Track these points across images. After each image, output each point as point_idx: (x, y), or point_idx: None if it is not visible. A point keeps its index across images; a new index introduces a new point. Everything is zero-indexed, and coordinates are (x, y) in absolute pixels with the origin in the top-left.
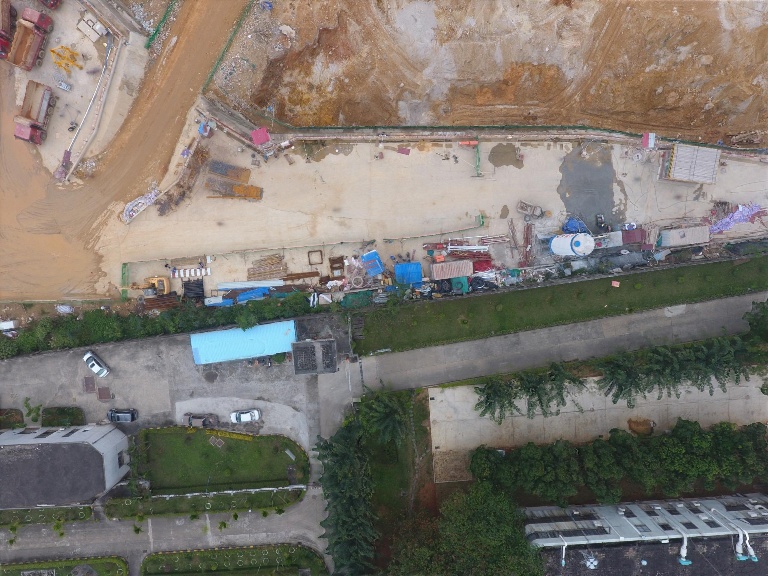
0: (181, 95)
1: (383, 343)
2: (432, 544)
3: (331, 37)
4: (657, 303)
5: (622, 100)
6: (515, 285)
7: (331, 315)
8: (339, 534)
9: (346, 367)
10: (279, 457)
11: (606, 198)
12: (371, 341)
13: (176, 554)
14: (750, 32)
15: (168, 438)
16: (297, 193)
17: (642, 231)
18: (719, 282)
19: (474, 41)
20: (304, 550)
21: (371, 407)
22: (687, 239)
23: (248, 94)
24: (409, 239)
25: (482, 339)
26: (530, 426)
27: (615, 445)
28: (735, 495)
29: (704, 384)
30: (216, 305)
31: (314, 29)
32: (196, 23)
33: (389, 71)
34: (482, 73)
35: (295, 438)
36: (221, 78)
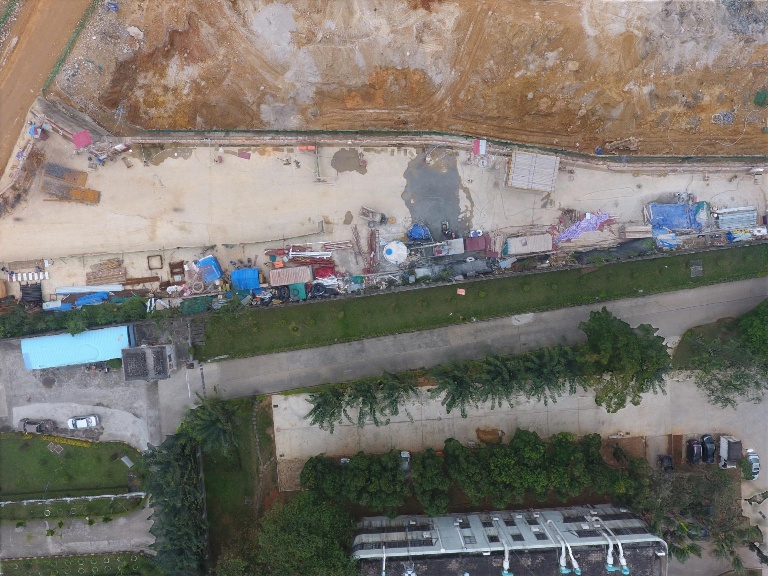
0: (21, 96)
1: (224, 349)
2: (251, 554)
3: (185, 39)
4: (503, 311)
5: (494, 105)
6: (356, 292)
7: (169, 321)
8: (164, 543)
9: (187, 373)
10: (119, 464)
11: (452, 205)
12: (212, 347)
13: (15, 561)
14: (614, 38)
15: (5, 444)
16: (136, 197)
17: (487, 238)
18: (567, 291)
19: (334, 45)
20: (145, 558)
21: (196, 415)
22: (529, 247)
23: (95, 96)
24: (251, 244)
25: (325, 346)
26: (376, 434)
27: (447, 455)
28: (585, 506)
29: (540, 394)
30: (54, 309)
31: (163, 31)
32: (38, 24)
33: (247, 74)
34: (346, 77)
35: (136, 445)
36: (63, 80)
